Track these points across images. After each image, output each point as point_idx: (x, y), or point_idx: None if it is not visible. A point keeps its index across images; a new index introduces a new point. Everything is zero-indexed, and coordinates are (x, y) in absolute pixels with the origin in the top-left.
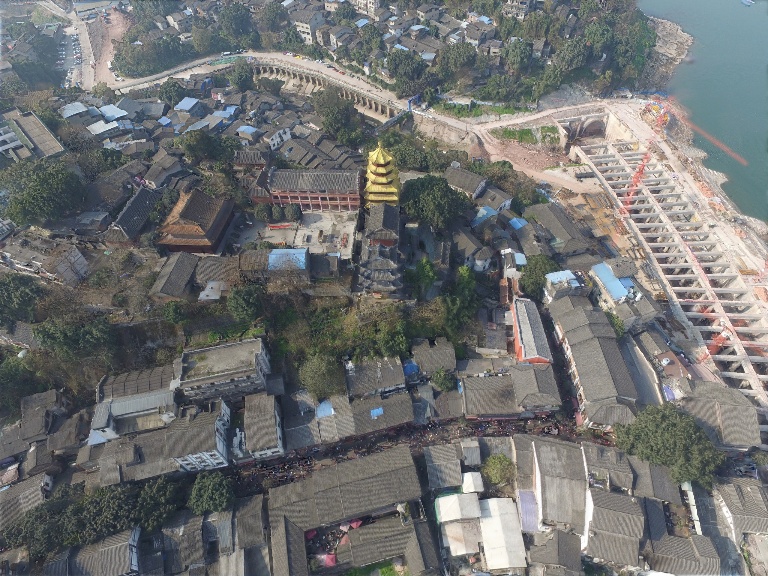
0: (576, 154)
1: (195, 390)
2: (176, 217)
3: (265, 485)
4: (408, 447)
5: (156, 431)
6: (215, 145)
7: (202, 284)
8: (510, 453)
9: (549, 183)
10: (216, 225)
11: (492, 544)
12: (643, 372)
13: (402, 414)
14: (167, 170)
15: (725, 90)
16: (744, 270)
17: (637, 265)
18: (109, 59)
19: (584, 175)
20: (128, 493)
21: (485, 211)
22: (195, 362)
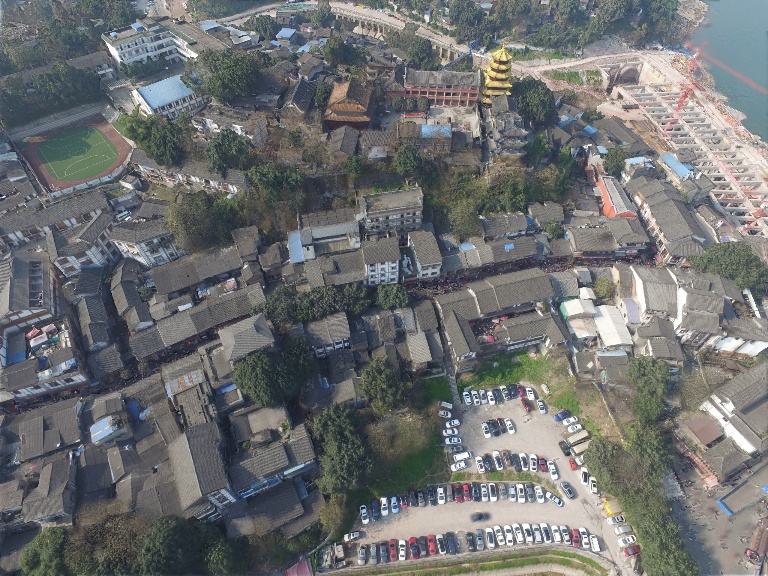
0: (618, 93)
1: (375, 222)
2: (342, 97)
3: (430, 295)
4: (538, 268)
5: (344, 254)
6: (351, 51)
7: (365, 150)
8: (611, 277)
9: None
10: (368, 108)
11: (606, 331)
12: (704, 229)
13: (528, 249)
14: (315, 68)
15: (739, 49)
16: (767, 178)
17: None
18: (182, 2)
19: (630, 106)
20: None
21: (567, 117)
22: (373, 202)
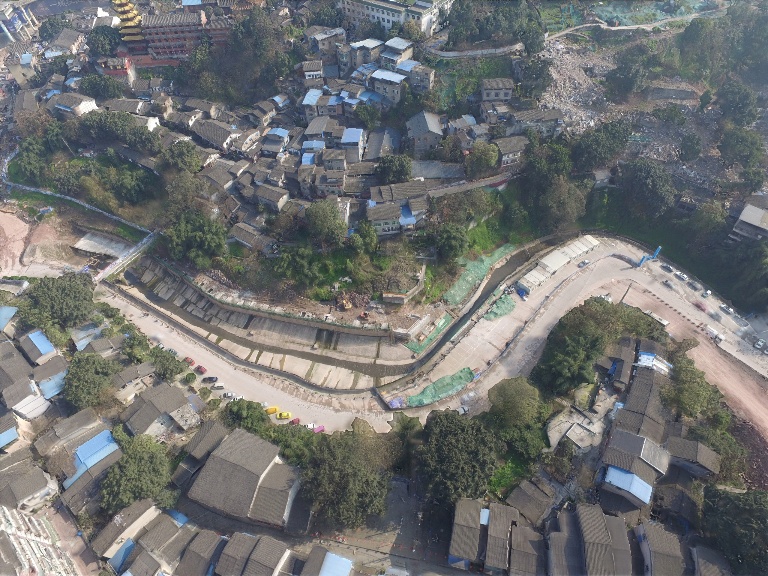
0: None
1: None
2: None
3: None
4: None
5: None
6: None
7: None
8: None
9: None
10: None
11: None
12: None
13: None
14: None
15: None
16: None
17: None
18: None
19: None
20: None
21: (74, 79)
22: None
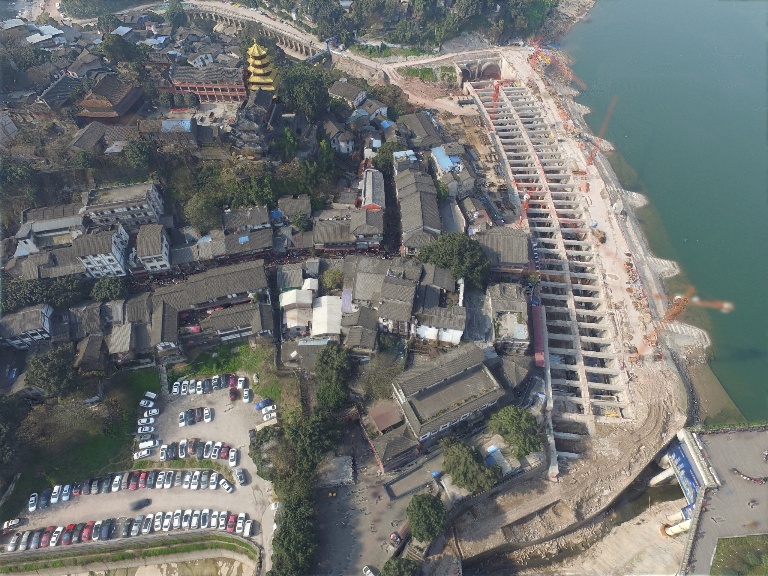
0: (467, 89)
1: (99, 216)
2: (90, 93)
3: (153, 287)
4: (263, 259)
5: (68, 247)
6: (130, 48)
7: (110, 145)
8: None
9: (437, 109)
10: (125, 104)
11: (318, 321)
12: (457, 220)
13: (263, 241)
14: (88, 65)
15: (610, 44)
16: (575, 171)
17: (491, 166)
18: (58, 2)
19: (465, 102)
20: (43, 282)
21: None
22: (100, 196)
